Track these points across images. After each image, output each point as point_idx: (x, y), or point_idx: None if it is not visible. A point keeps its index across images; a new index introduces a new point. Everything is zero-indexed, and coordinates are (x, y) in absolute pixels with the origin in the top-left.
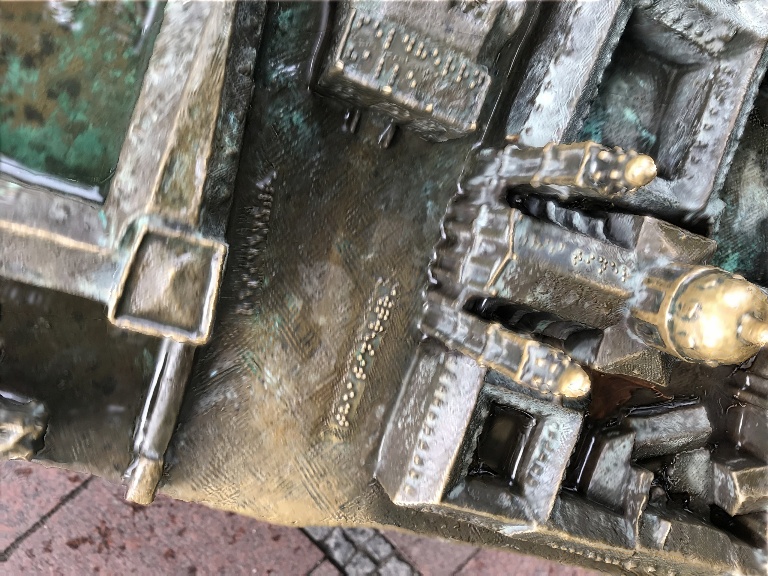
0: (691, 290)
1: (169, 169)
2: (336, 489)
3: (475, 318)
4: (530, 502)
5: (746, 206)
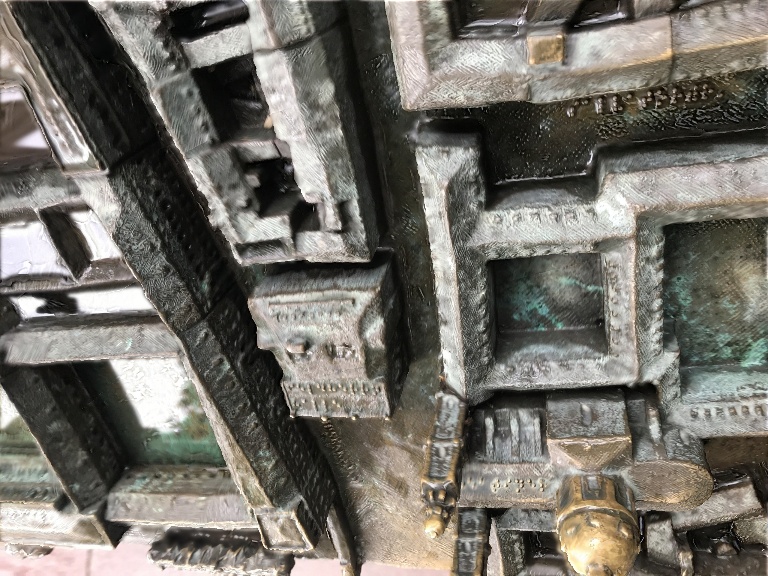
0: (564, 529)
1: (247, 491)
2: None
3: None
4: None
5: (754, 297)
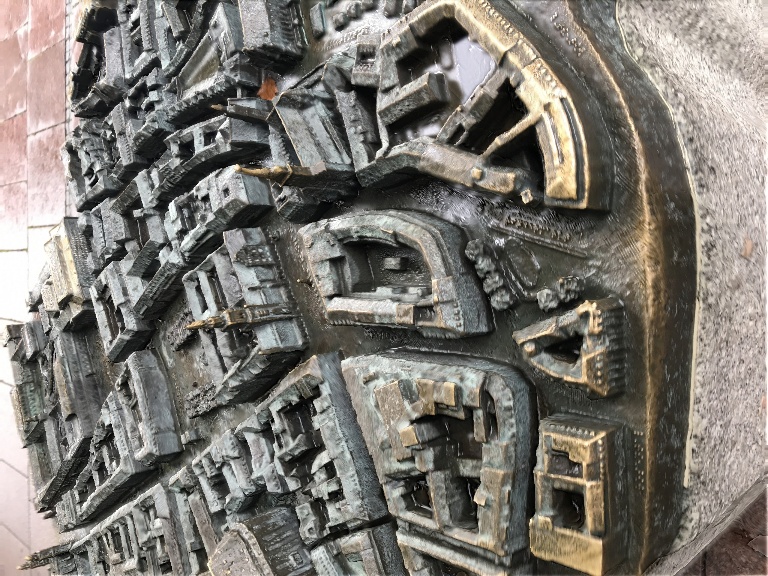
0: None
1: None
2: None
3: None
4: None
5: None
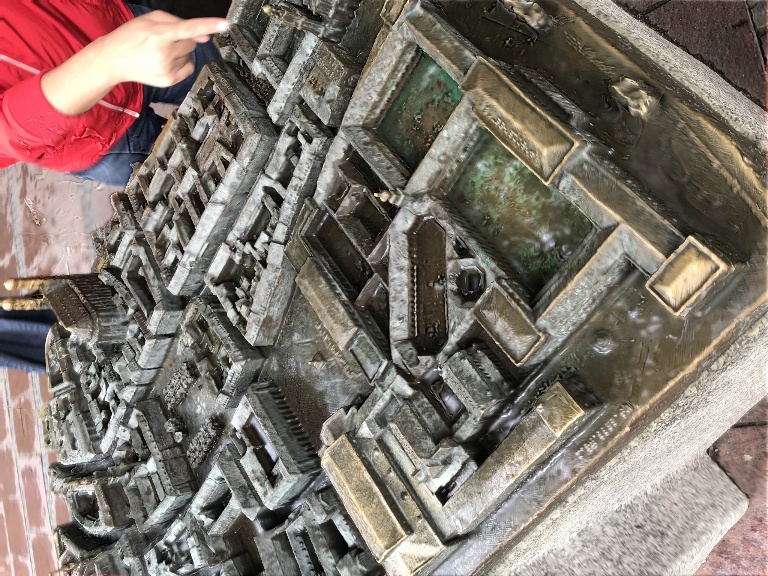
0: None
1: None
2: None
3: None
4: None
5: None
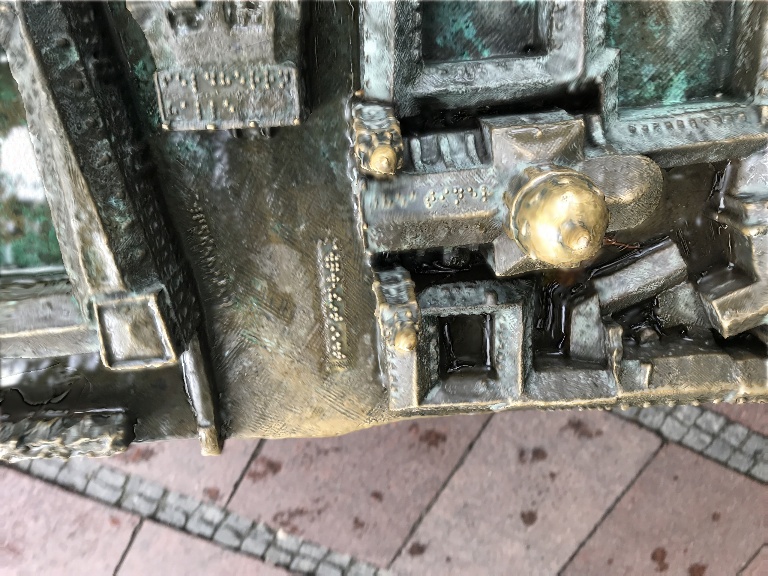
0: (523, 207)
1: (87, 261)
2: (358, 403)
3: (373, 271)
4: (504, 382)
5: (677, 17)
